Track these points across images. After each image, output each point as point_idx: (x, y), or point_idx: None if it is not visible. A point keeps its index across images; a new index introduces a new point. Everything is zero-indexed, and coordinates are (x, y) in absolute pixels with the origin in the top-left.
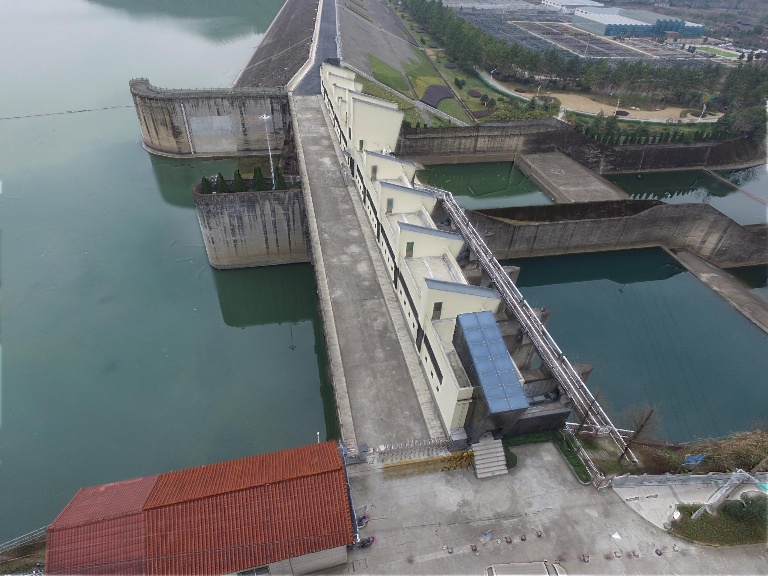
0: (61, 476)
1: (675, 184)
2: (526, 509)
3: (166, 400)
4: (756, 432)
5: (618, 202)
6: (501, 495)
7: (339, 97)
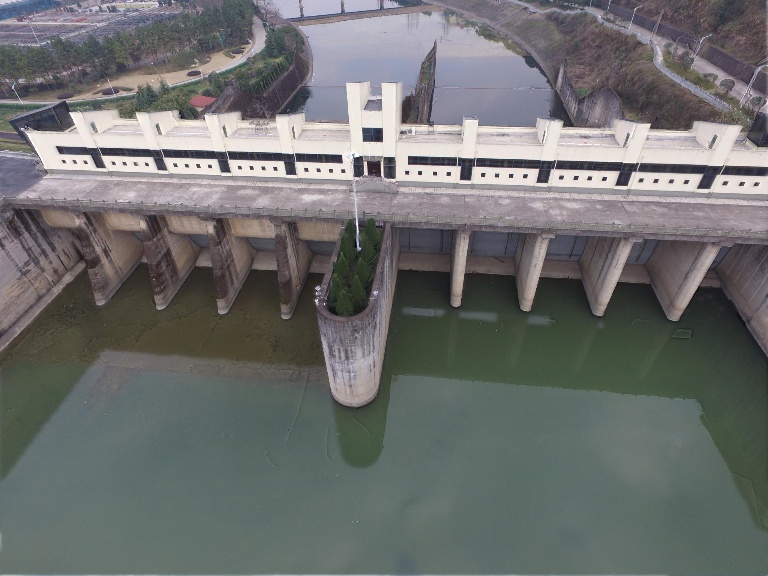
0: None
1: (294, 107)
2: None
3: (627, 463)
4: None
5: None
6: None
7: (222, 127)
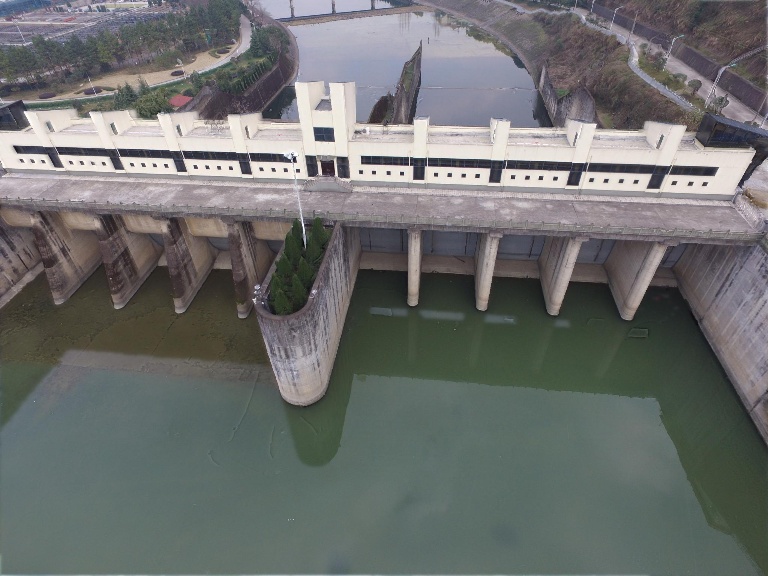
0: (697, 570)
1: (278, 107)
2: (767, 189)
3: (567, 462)
4: (680, 122)
5: (375, 109)
6: (762, 194)
7: (176, 126)
